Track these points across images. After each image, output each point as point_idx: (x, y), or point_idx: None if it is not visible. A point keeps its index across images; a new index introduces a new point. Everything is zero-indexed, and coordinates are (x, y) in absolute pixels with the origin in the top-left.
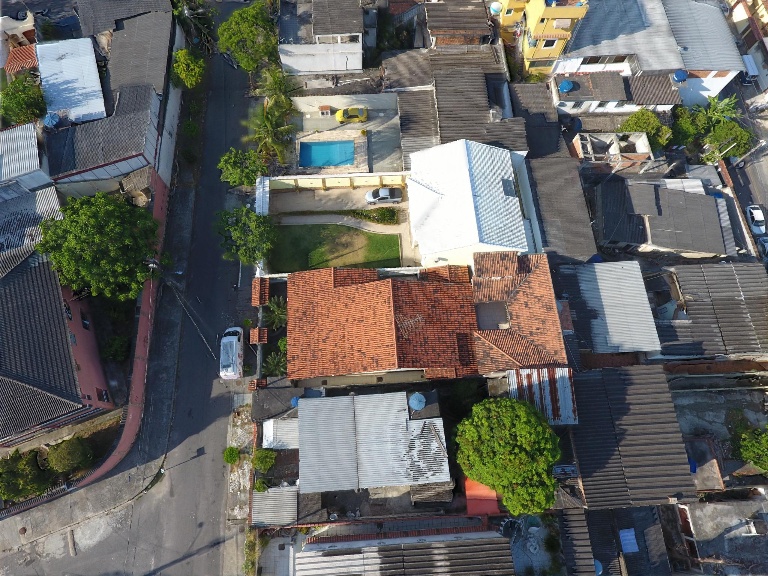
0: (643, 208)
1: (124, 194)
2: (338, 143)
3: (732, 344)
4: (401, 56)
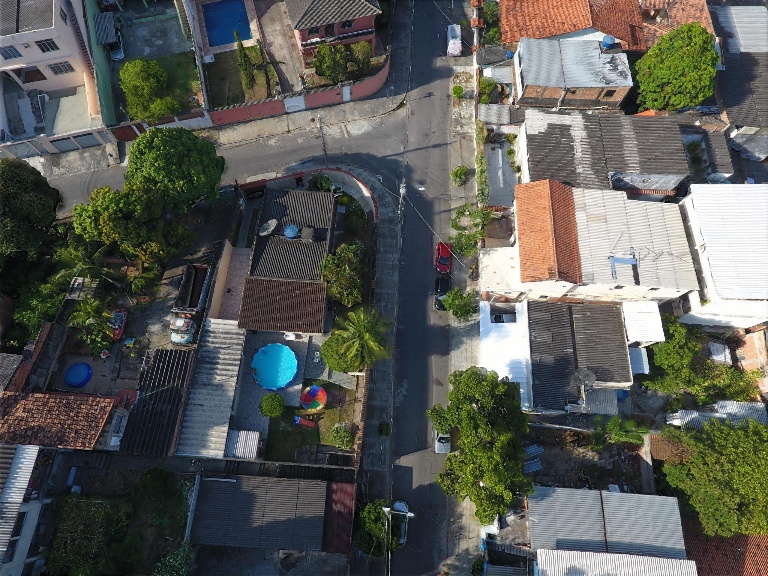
0: None
1: None
2: None
3: None
4: None
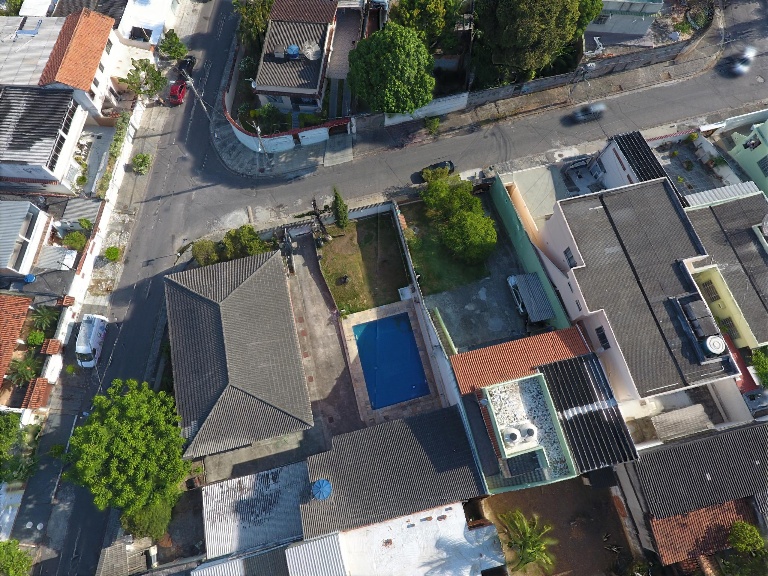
0: None
1: None
2: None
3: None
4: None
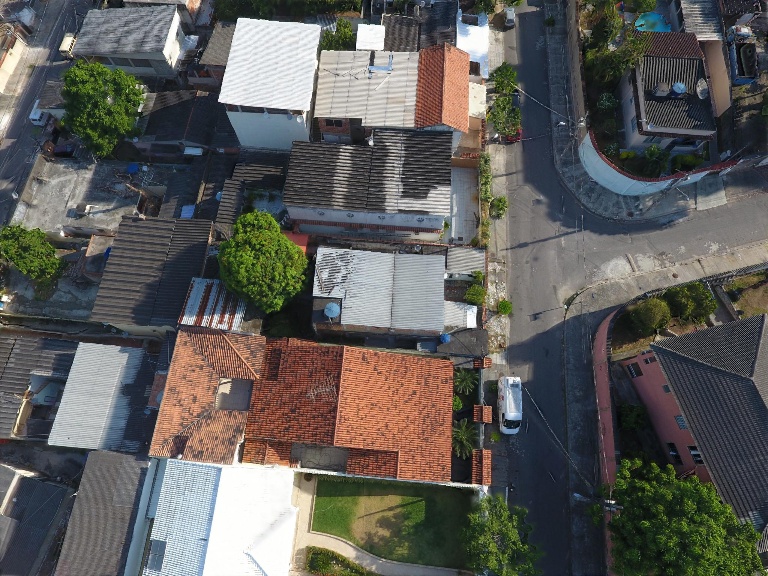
0: None
1: None
2: None
3: (6, 344)
4: None
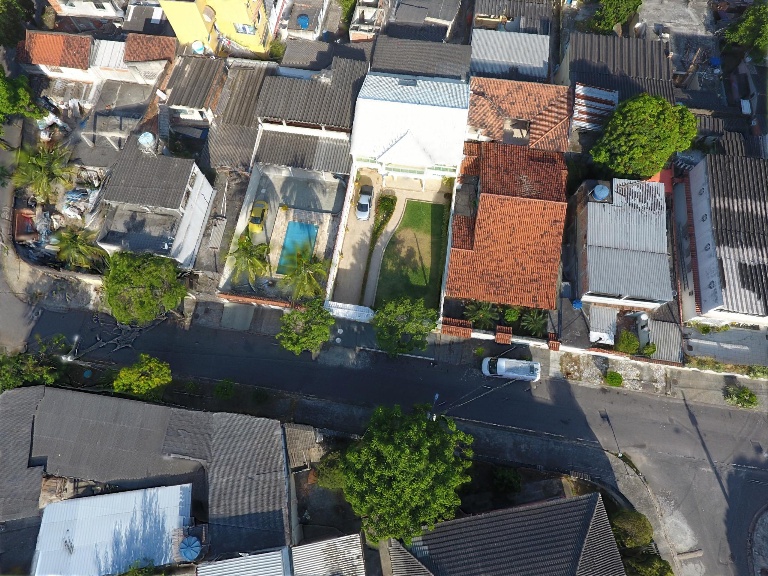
0: (420, 17)
1: (309, 467)
2: (286, 238)
3: None
4: (211, 149)
